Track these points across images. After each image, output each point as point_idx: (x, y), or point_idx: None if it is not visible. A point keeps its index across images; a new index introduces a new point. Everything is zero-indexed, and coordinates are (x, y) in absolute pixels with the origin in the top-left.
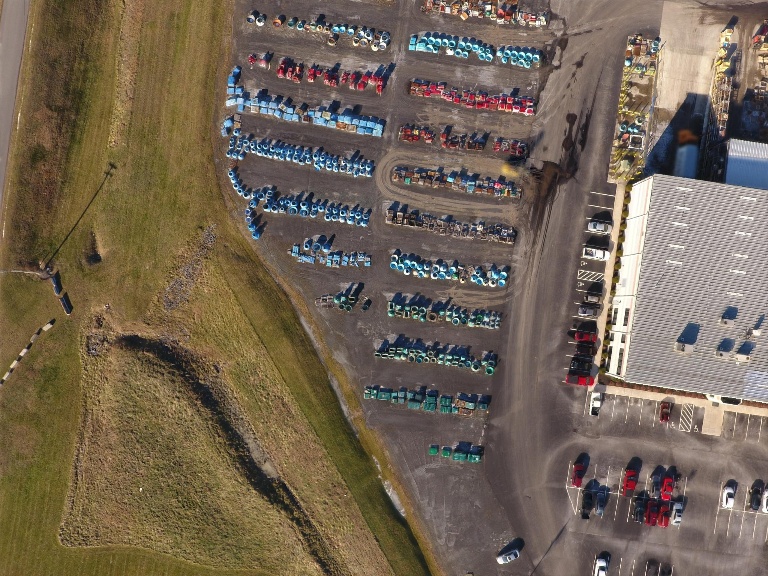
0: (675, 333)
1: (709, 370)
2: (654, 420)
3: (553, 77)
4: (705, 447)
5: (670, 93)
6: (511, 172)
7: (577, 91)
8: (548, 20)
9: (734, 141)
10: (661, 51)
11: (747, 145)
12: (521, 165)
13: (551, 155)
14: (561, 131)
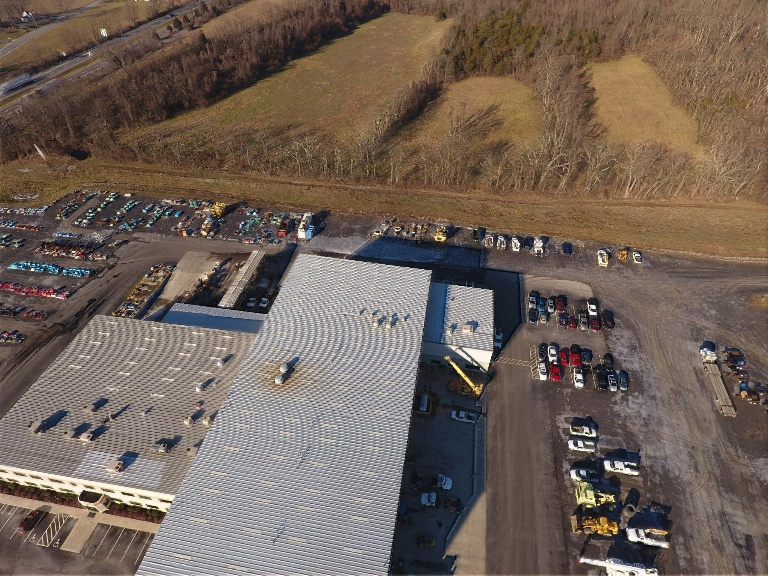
0: (41, 418)
1: (53, 450)
2: (16, 531)
3: (94, 282)
4: (55, 566)
5: (172, 291)
6: (25, 328)
7: (105, 288)
8: (109, 258)
9: (177, 304)
10: (174, 271)
11: (185, 306)
12: (36, 325)
13: (63, 320)
14: (80, 307)
